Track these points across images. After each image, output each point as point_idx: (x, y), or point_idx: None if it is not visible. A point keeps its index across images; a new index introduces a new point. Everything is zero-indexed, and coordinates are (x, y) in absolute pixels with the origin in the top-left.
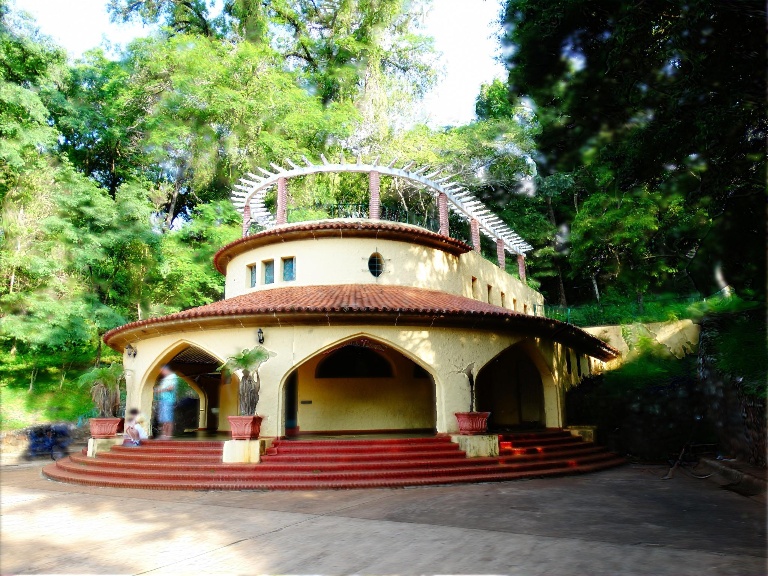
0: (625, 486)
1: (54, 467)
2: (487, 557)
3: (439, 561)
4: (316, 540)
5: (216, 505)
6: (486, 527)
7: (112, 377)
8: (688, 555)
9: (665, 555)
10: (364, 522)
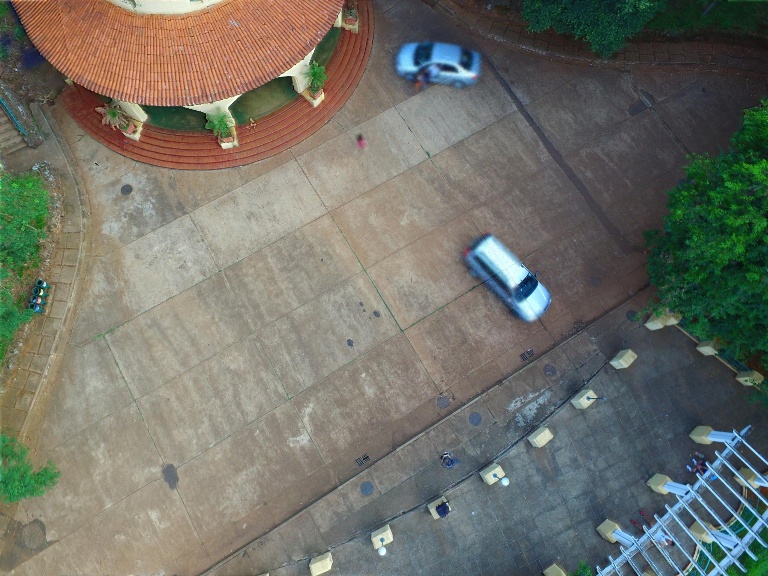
0: (402, 17)
1: (206, 165)
2: (450, 98)
3: (447, 105)
4: (419, 116)
5: (360, 124)
6: (431, 84)
7: (228, 119)
8: (468, 72)
9: (466, 75)
10: (410, 102)
